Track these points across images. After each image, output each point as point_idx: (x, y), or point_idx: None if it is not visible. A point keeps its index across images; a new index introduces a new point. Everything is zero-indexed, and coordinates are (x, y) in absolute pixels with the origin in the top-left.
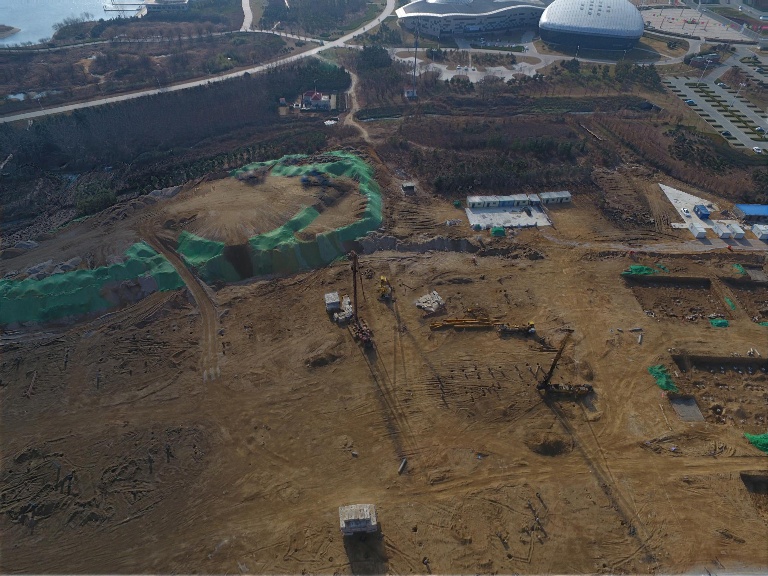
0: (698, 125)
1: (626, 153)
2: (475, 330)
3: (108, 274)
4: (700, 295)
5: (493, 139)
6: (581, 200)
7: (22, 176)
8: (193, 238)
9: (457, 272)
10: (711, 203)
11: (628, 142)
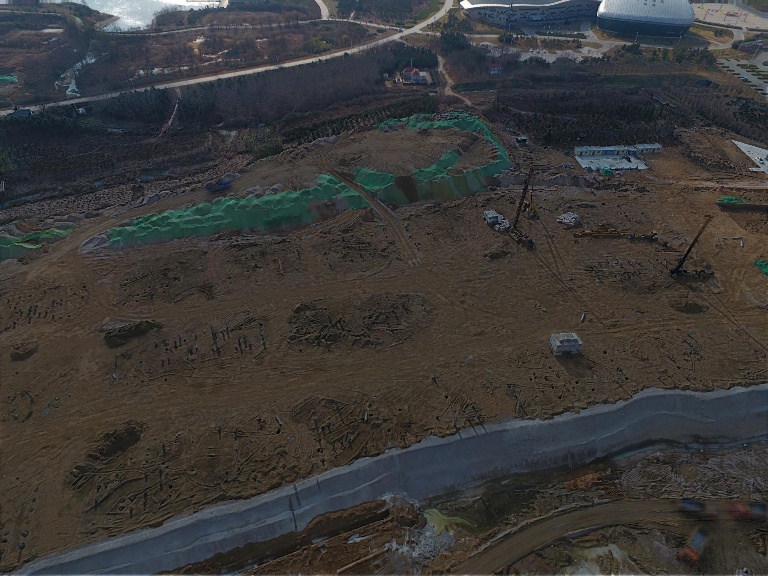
0: (755, 97)
1: (696, 118)
2: (609, 238)
3: (311, 195)
4: None
5: (585, 104)
6: (669, 151)
7: (194, 130)
8: (367, 171)
9: (582, 200)
10: None
11: (698, 109)
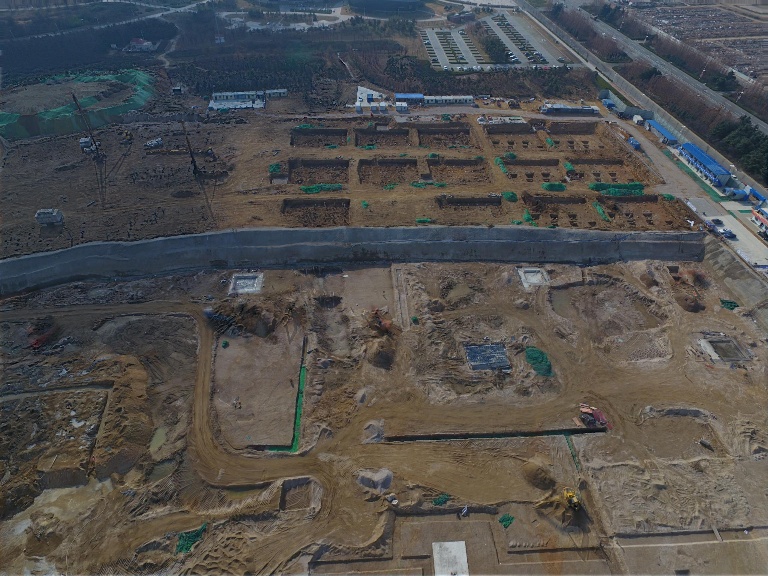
0: None
1: (356, 72)
2: (175, 154)
3: None
4: (337, 138)
5: (253, 62)
6: (296, 95)
7: None
8: None
9: None
10: (381, 94)
11: (358, 65)
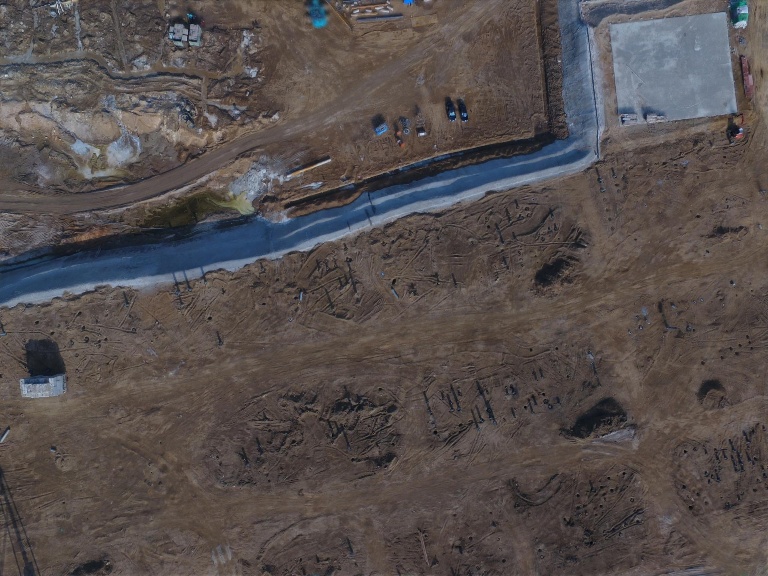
0: None
1: None
2: None
3: None
4: None
5: None
6: None
7: None
8: None
9: None
10: None
11: None
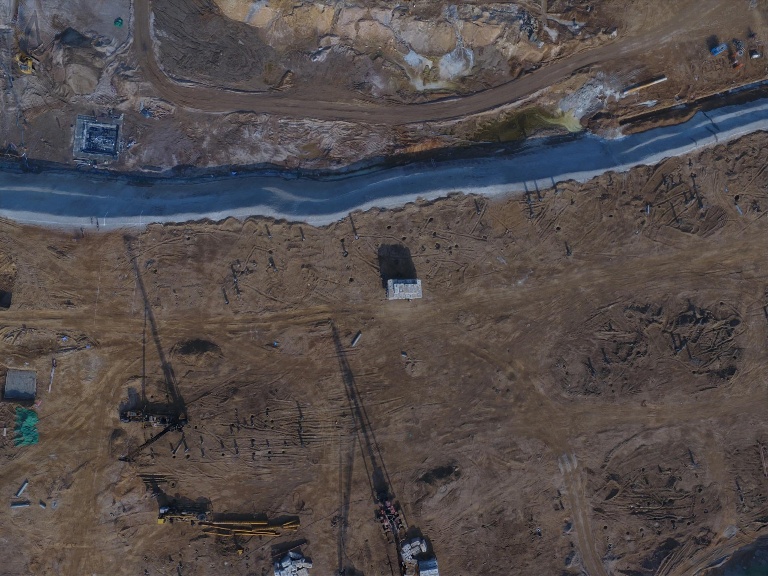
0: None
1: None
2: (240, 516)
3: None
4: None
5: None
6: None
7: None
8: None
9: None
10: None
11: None
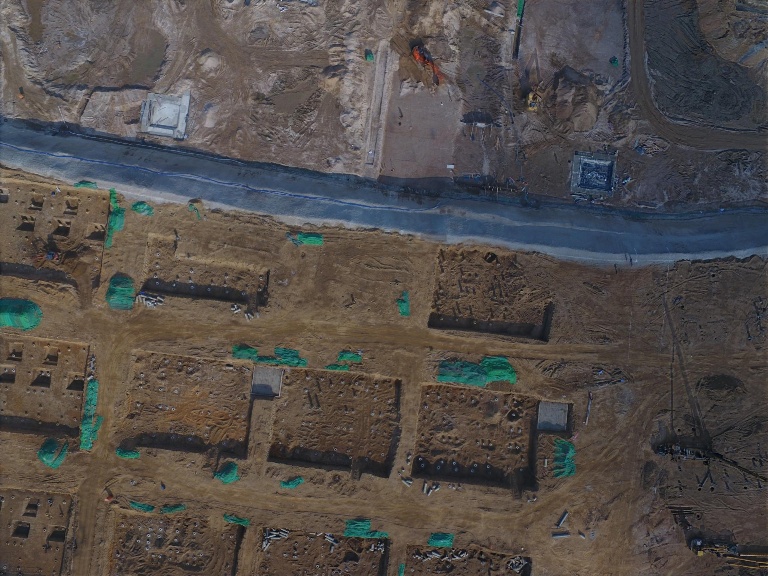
0: None
1: None
2: (763, 548)
3: None
4: None
5: None
6: None
7: None
8: None
9: None
10: None
11: None
